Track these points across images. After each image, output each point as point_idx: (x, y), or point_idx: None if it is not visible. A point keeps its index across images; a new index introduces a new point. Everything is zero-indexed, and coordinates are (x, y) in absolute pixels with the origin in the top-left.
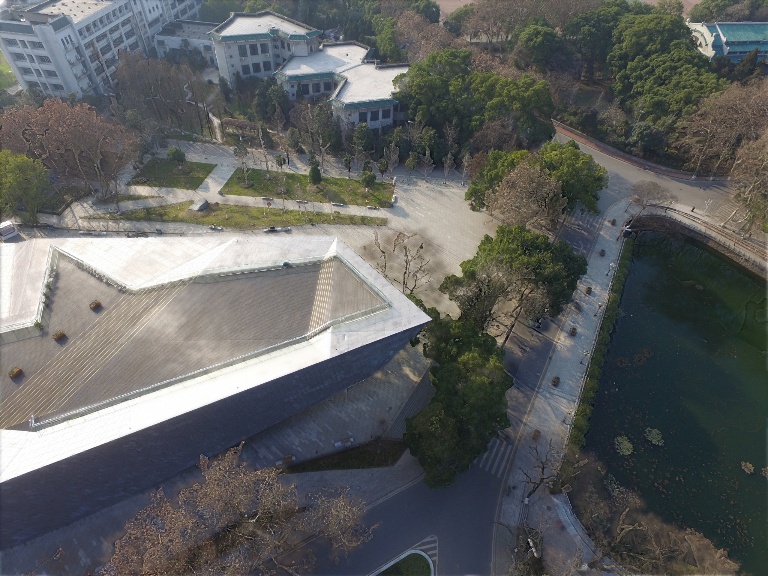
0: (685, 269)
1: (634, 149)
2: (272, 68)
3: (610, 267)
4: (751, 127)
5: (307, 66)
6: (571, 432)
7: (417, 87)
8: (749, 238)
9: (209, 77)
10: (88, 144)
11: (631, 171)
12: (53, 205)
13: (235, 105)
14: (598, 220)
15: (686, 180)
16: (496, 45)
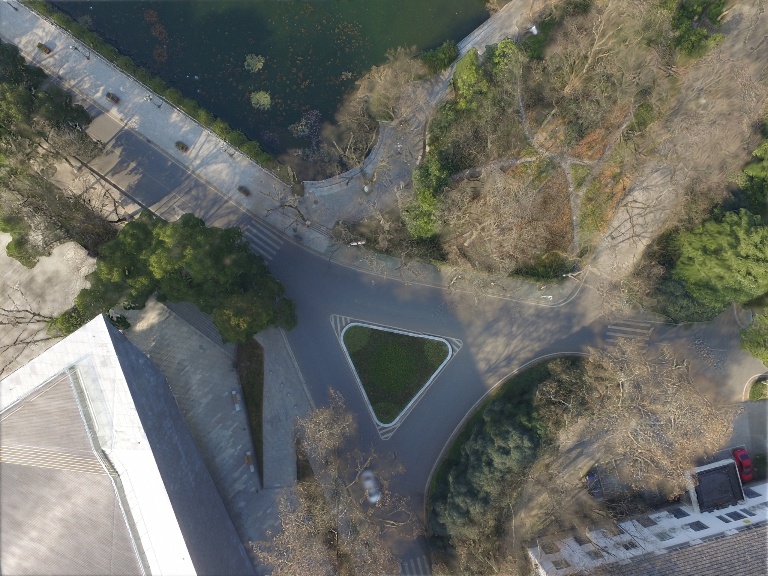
0: None
1: None
2: None
3: None
4: None
5: None
6: (244, 153)
7: None
8: None
9: None
10: None
11: None
12: None
13: None
14: None
15: None
16: None
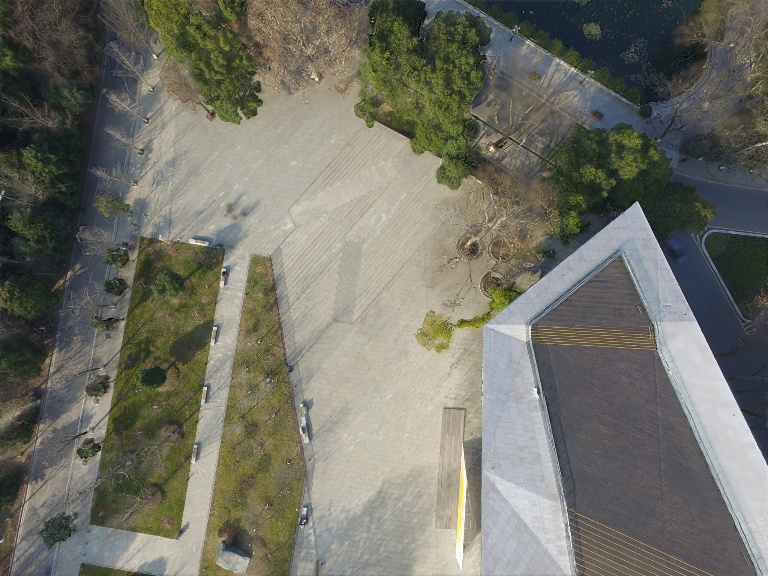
0: None
1: None
2: None
3: None
4: None
5: None
6: (594, 79)
7: None
8: None
9: None
10: None
11: None
12: None
13: None
14: None
15: None
16: None
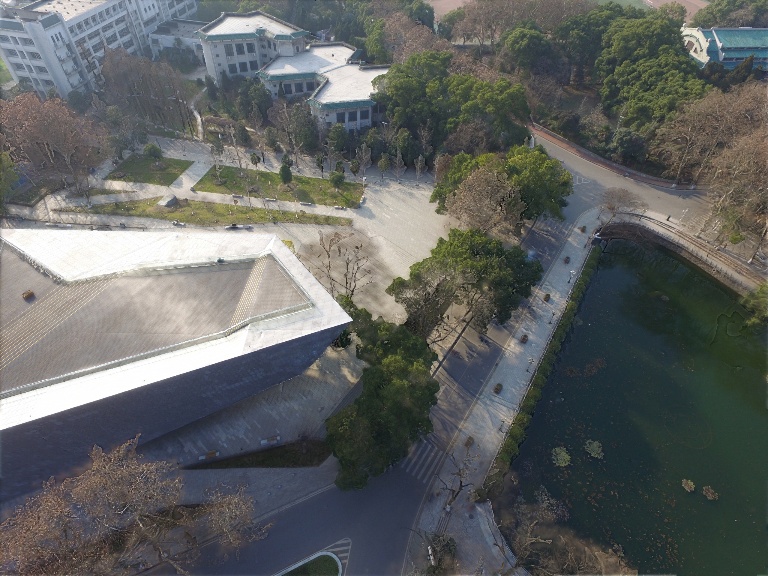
0: (660, 279)
1: (614, 155)
2: (259, 67)
3: (571, 274)
4: (733, 135)
5: (291, 66)
6: (506, 440)
7: (394, 88)
8: (723, 249)
9: (200, 75)
10: (54, 138)
11: (610, 178)
12: (29, 197)
13: (219, 103)
14: (568, 226)
15: (666, 188)
16: (490, 48)
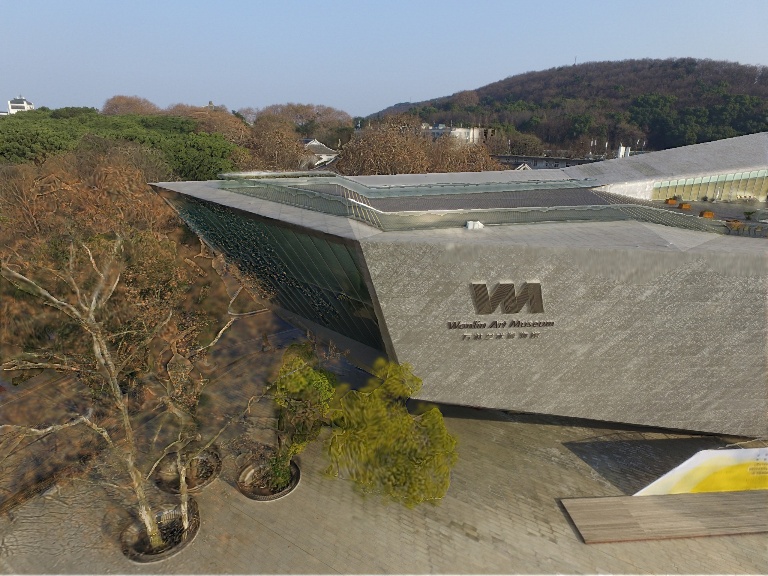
0: None
1: None
2: None
3: None
4: None
5: None
6: None
7: None
8: None
9: None
10: None
11: None
12: None
13: None
14: None
15: None
16: None
